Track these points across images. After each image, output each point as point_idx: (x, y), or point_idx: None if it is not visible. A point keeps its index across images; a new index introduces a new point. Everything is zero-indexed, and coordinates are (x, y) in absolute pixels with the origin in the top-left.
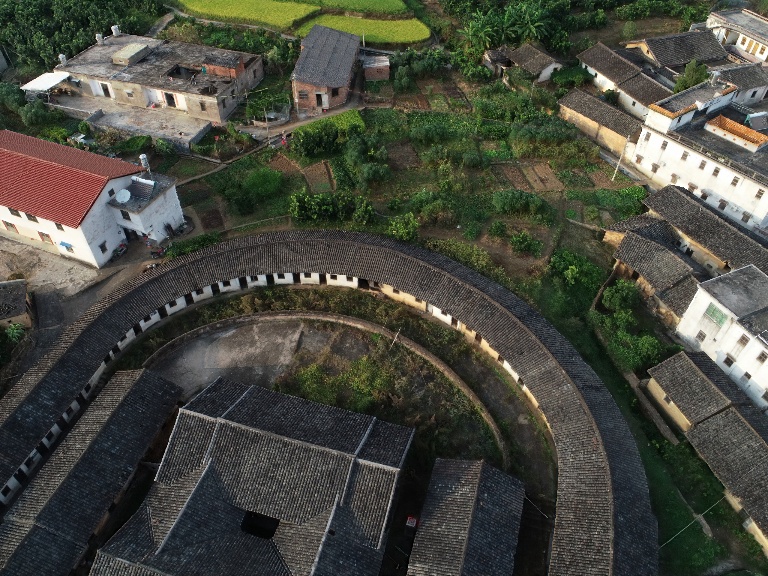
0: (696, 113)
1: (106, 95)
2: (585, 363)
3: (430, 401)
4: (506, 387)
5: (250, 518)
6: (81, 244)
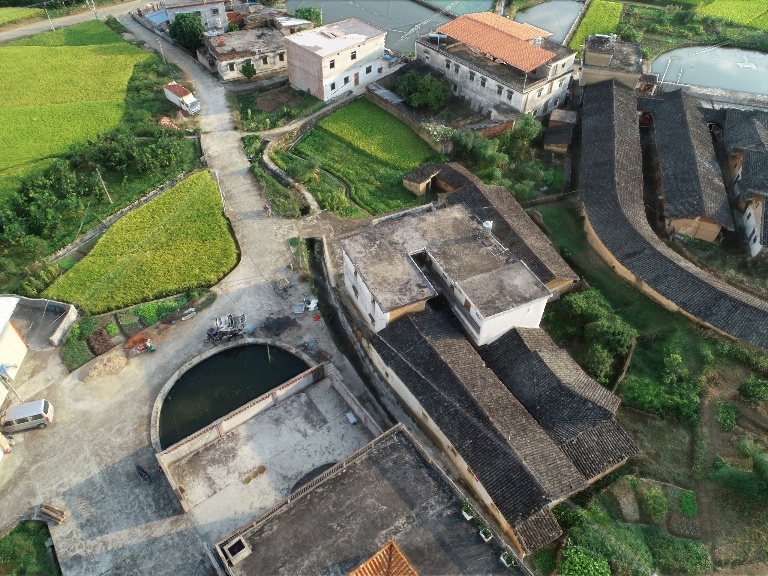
0: None
1: None
2: (641, 277)
3: None
4: None
5: None
6: None
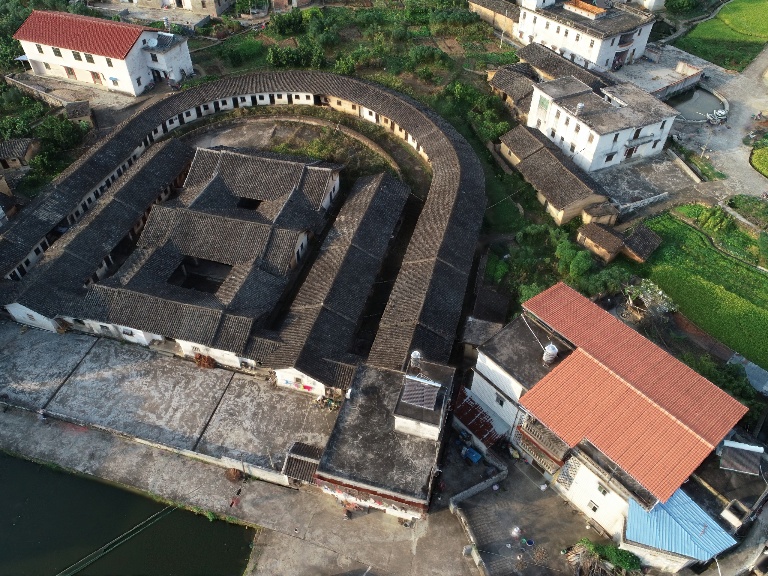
0: (561, 0)
1: (130, 1)
2: (458, 133)
3: (358, 159)
4: (409, 153)
5: (242, 204)
6: (124, 76)
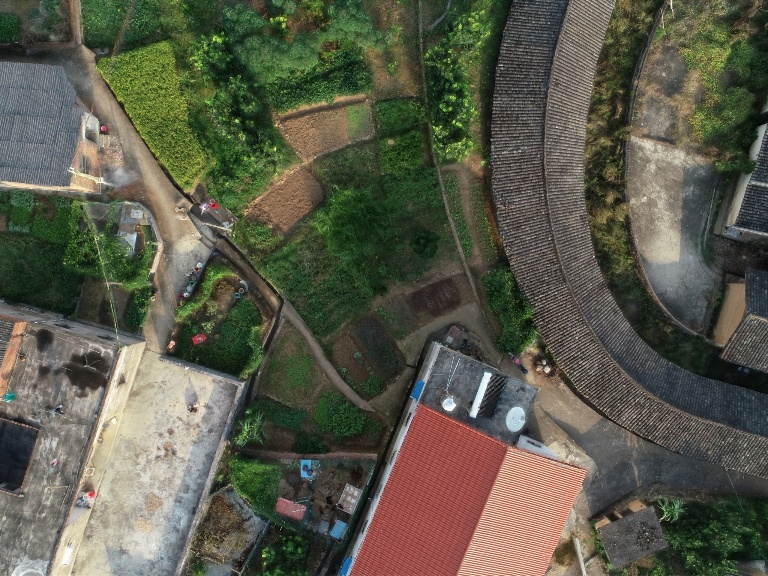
0: None
1: None
2: None
3: None
4: None
5: None
6: None
